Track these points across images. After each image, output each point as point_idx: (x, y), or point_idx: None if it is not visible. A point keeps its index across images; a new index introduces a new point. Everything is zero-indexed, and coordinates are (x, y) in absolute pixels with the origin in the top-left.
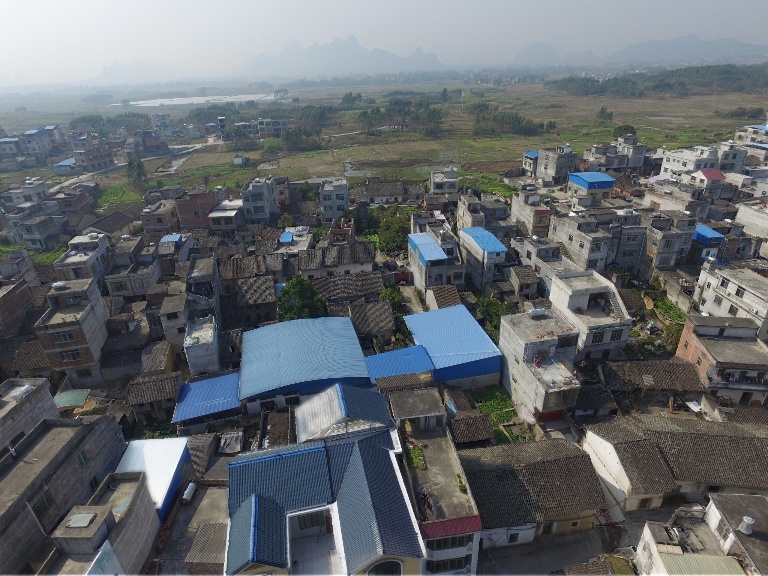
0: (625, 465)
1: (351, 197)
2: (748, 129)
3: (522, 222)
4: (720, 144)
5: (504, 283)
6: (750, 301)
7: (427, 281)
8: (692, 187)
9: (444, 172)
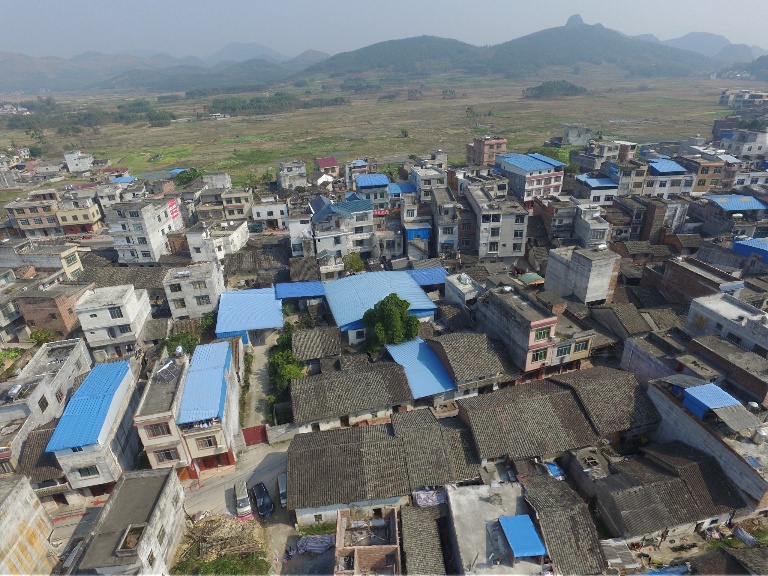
0: None
1: None
2: None
3: None
4: None
5: None
6: None
7: None
8: None
9: None
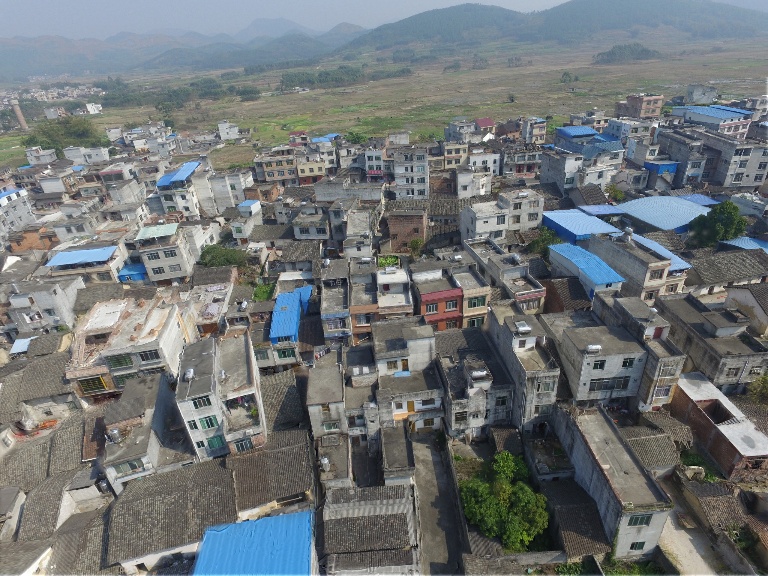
0: None
1: None
2: None
3: None
4: None
5: None
6: None
7: None
8: (195, 351)
9: None
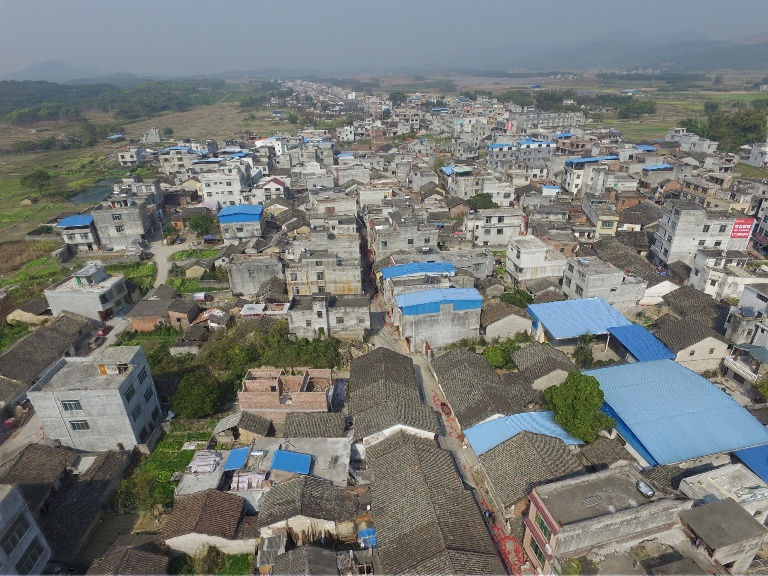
0: None
1: (1, 406)
2: (170, 151)
3: None
4: (230, 162)
5: None
6: (509, 221)
7: None
8: (337, 188)
9: (86, 277)
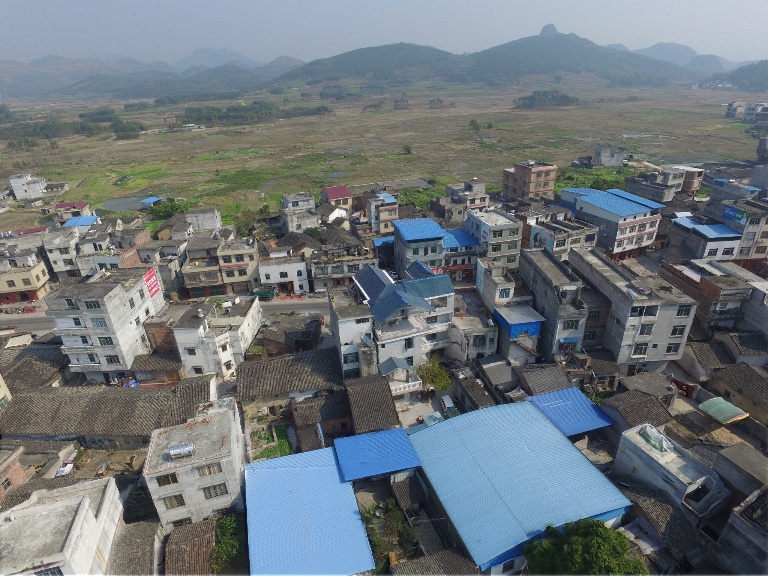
0: None
1: None
2: None
3: None
4: None
5: None
6: None
7: None
8: None
9: None
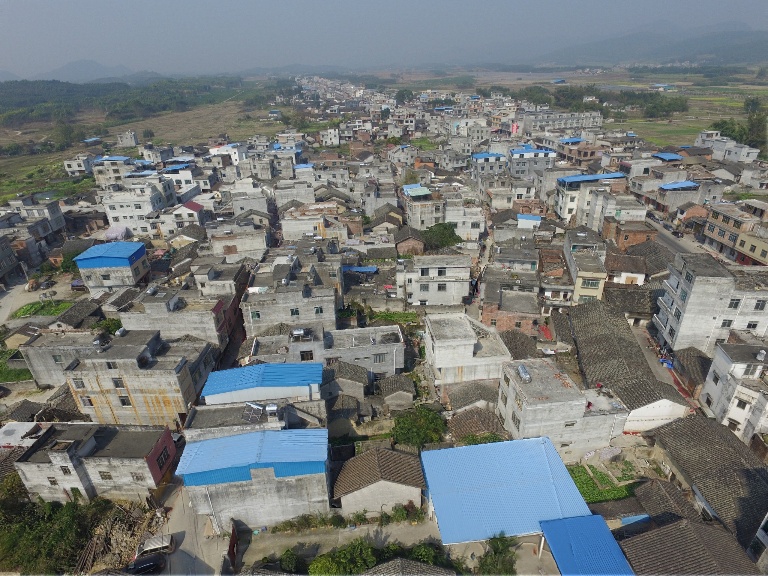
0: (677, 401)
1: None
2: (104, 162)
3: (187, 337)
4: (146, 179)
5: (343, 402)
6: (453, 274)
7: (328, 488)
8: (244, 219)
9: None
